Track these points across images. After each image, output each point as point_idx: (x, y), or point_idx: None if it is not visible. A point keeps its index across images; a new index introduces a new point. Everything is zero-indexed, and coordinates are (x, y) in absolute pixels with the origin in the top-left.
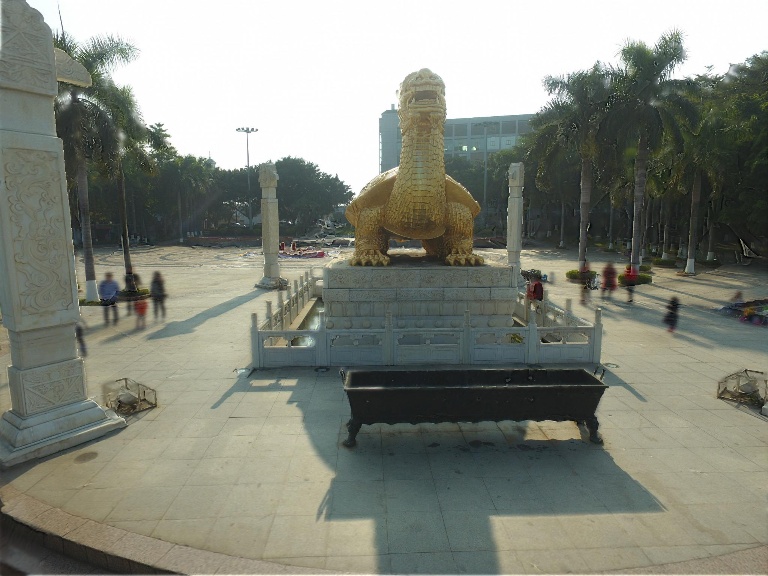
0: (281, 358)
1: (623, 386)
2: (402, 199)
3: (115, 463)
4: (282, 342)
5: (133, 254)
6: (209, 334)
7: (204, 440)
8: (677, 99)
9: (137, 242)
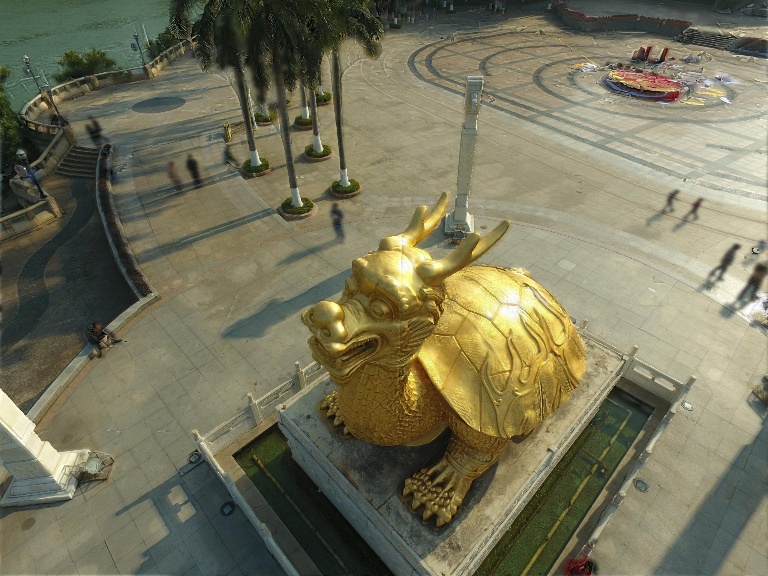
0: None
1: None
2: None
3: (26, 546)
4: None
5: (472, 40)
6: (265, 351)
7: (66, 562)
8: None
9: (493, 13)
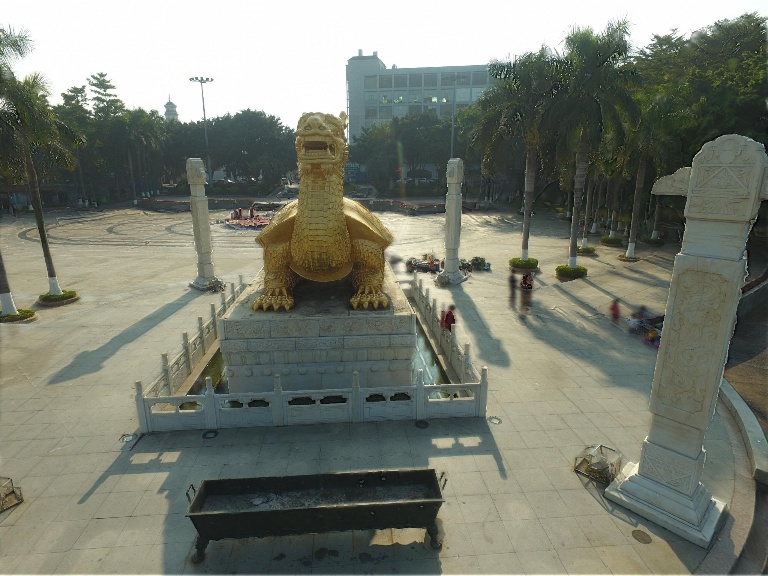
0: (170, 423)
1: (493, 455)
2: (300, 247)
3: None
4: (185, 387)
5: (80, 223)
6: (114, 374)
7: (55, 557)
8: (618, 93)
9: (86, 206)
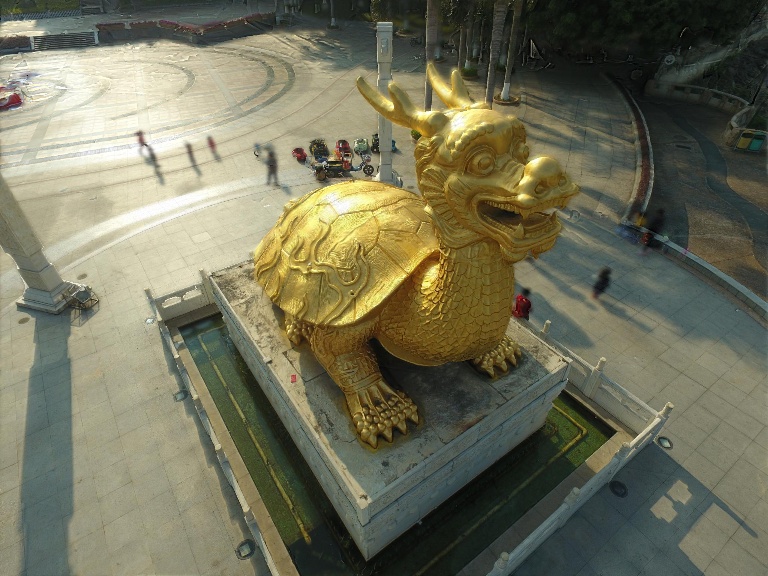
0: None
1: (715, 503)
2: (455, 352)
3: None
4: None
5: None
6: None
7: None
8: None
9: None
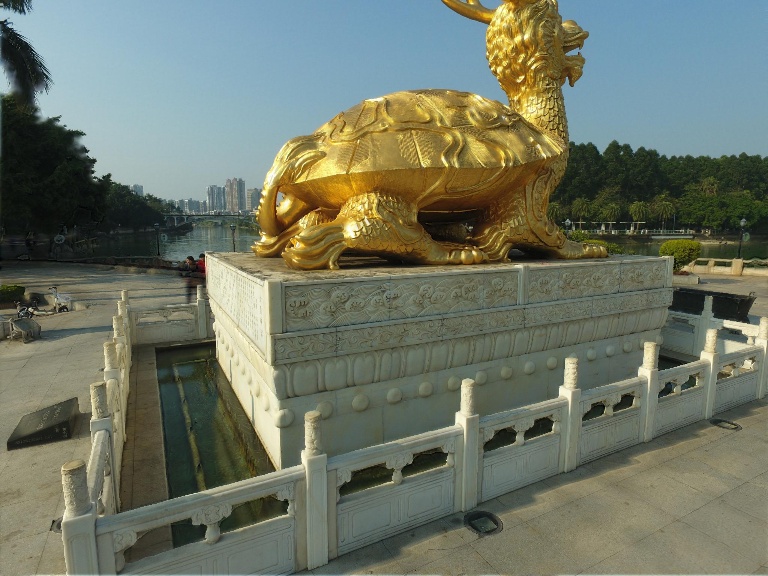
0: None
1: None
2: None
3: None
4: None
5: None
6: None
7: None
8: None
9: None
